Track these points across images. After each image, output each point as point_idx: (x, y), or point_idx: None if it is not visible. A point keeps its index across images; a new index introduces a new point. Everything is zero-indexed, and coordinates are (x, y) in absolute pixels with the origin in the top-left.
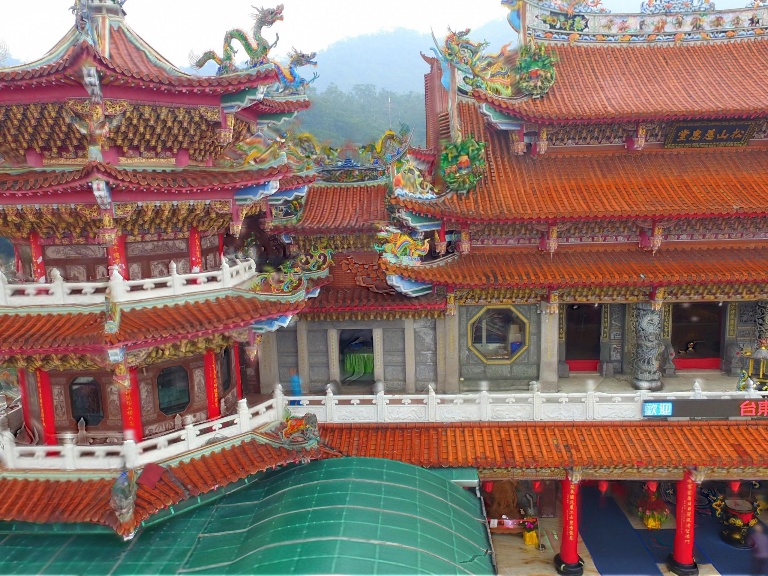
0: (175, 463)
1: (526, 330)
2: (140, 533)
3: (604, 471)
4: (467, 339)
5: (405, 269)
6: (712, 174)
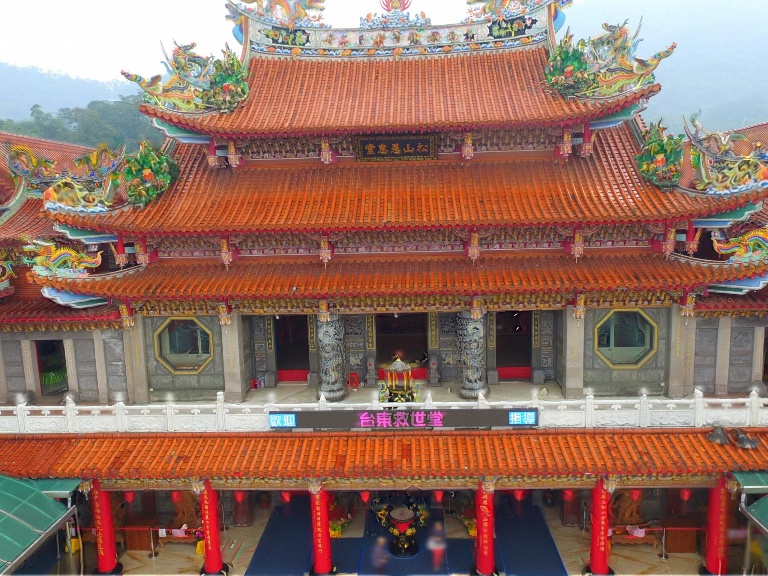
0: None
1: (210, 341)
2: None
3: (233, 481)
4: (154, 350)
5: (57, 282)
6: (391, 188)
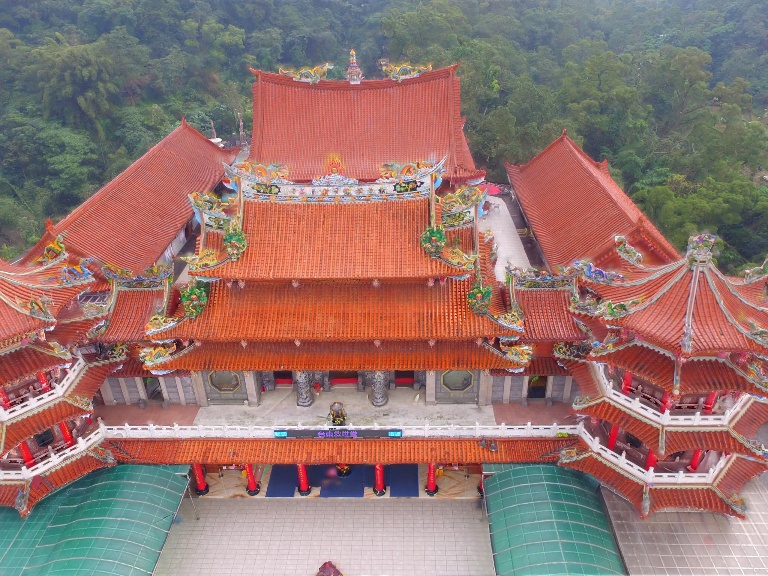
0: (48, 473)
1: (238, 379)
2: (35, 506)
3: None
4: (208, 382)
5: (158, 367)
6: (333, 303)
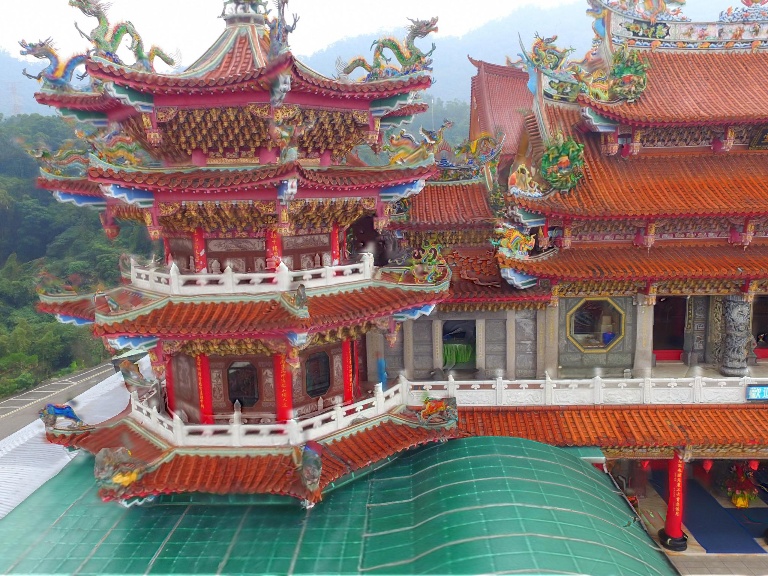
0: (330, 441)
1: (622, 321)
2: None
3: (711, 451)
4: (566, 329)
5: (519, 263)
6: None
